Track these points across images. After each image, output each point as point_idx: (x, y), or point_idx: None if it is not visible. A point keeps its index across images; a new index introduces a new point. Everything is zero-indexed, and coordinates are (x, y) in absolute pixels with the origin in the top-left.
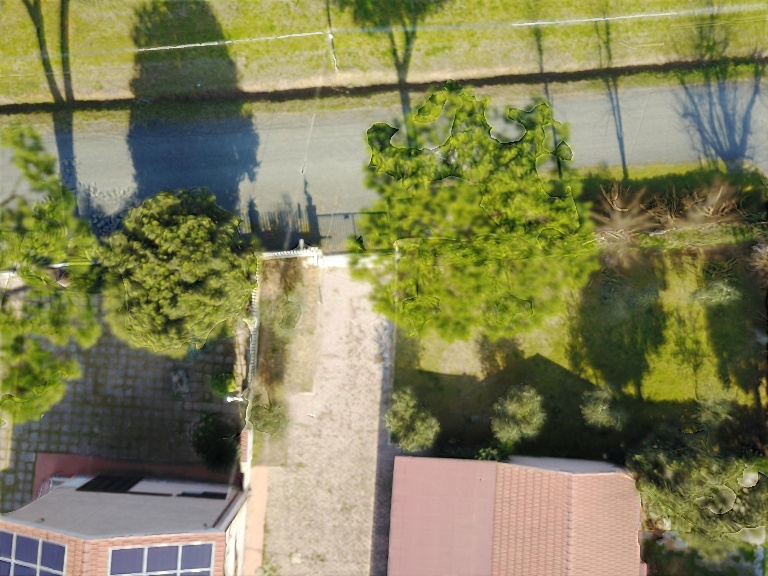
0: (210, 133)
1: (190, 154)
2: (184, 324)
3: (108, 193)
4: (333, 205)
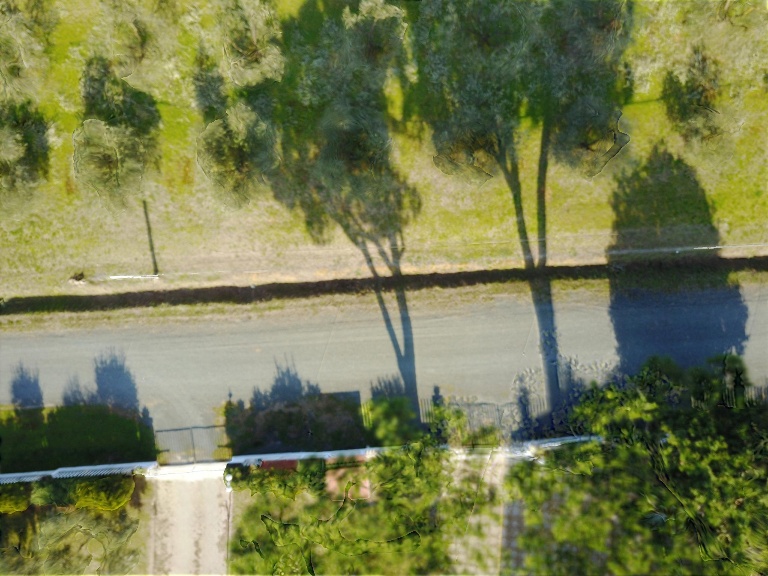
0: (695, 304)
1: (674, 326)
2: None
3: (589, 366)
4: None
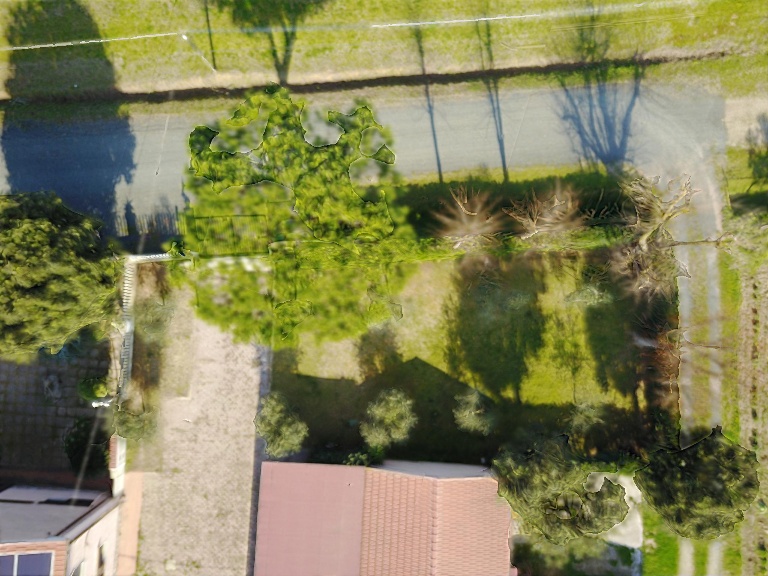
0: (86, 135)
1: (65, 156)
2: (23, 330)
3: None
4: (211, 208)
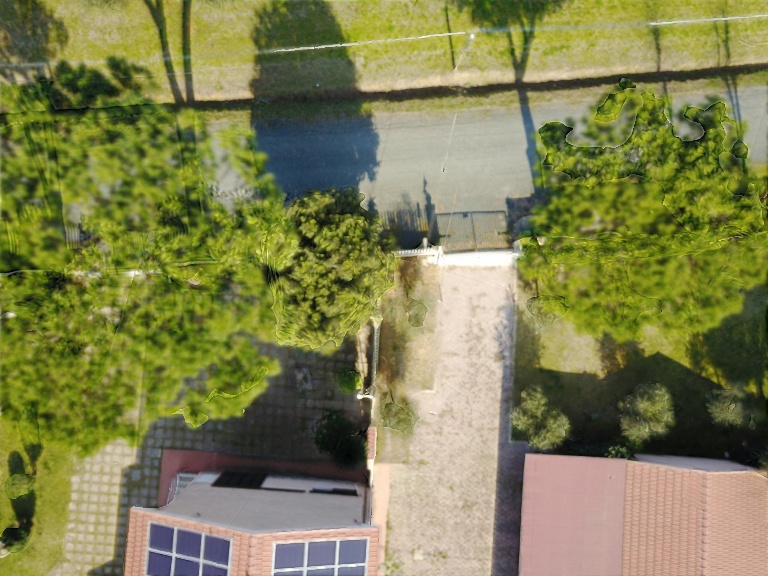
0: (330, 133)
1: (310, 154)
2: (338, 322)
3: (230, 192)
4: (452, 204)
